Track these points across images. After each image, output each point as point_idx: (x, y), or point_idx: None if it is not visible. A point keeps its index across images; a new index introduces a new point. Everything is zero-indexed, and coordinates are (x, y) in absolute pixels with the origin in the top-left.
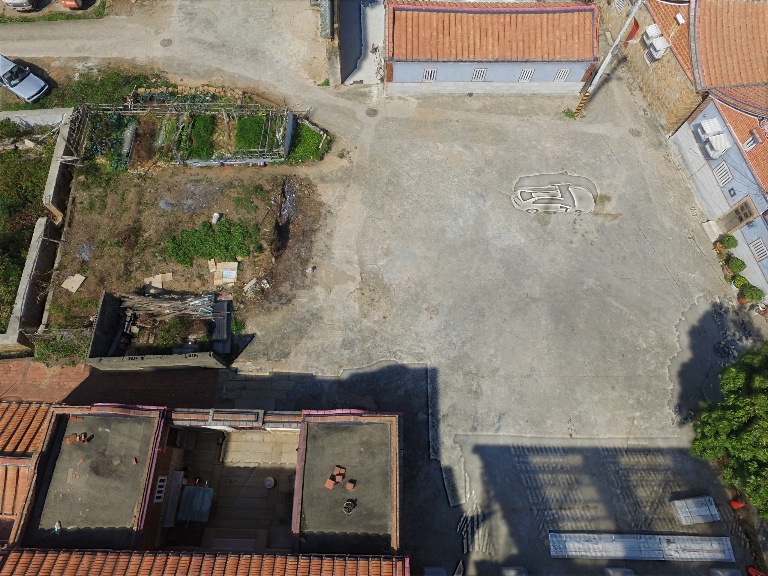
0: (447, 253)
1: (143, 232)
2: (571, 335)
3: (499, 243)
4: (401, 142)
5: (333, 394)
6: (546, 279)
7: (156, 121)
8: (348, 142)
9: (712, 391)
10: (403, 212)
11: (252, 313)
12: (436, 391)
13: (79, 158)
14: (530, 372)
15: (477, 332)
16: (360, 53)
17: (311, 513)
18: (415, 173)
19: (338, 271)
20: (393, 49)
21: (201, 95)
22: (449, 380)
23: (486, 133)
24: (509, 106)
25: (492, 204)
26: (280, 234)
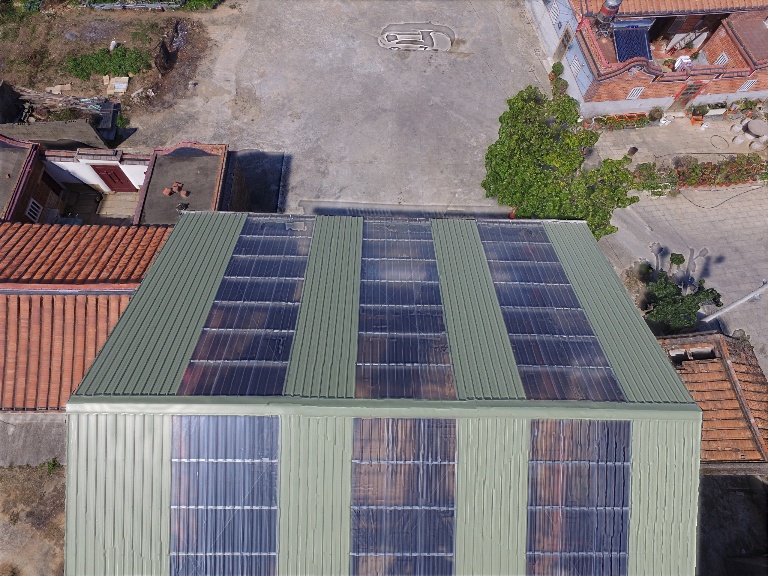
0: (315, 77)
1: (48, 55)
2: (412, 135)
3: (361, 70)
4: None
5: None
6: (398, 96)
7: None
8: None
9: None
10: (281, 47)
11: (137, 113)
12: (289, 171)
13: None
14: (372, 160)
15: (331, 131)
16: None
17: (150, 212)
18: (296, 20)
19: (217, 87)
20: None
21: None
22: (301, 164)
23: None
24: None
25: (360, 43)
26: (169, 58)
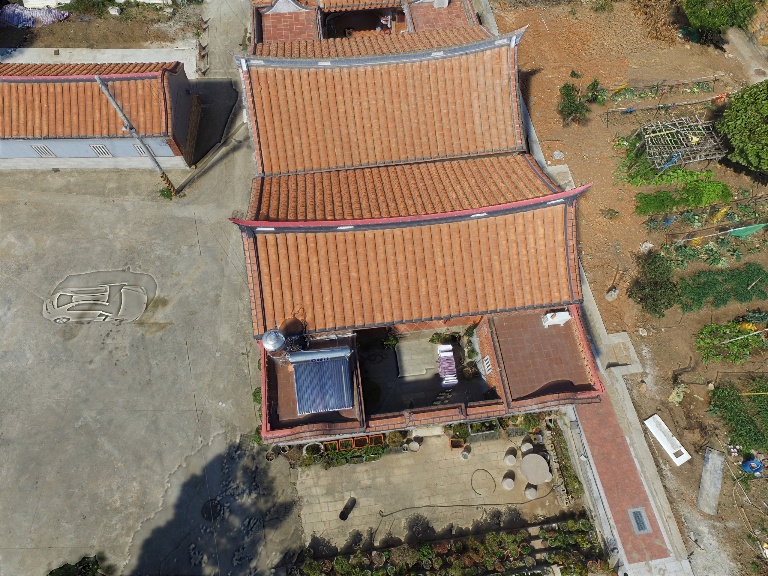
0: None
1: None
2: (31, 490)
3: None
4: None
5: None
6: (35, 413)
7: None
8: None
9: (171, 568)
10: None
11: None
12: None
13: None
14: None
15: None
16: None
17: None
18: None
19: None
20: None
21: None
22: None
23: (53, 219)
24: (97, 184)
25: (16, 312)
26: None
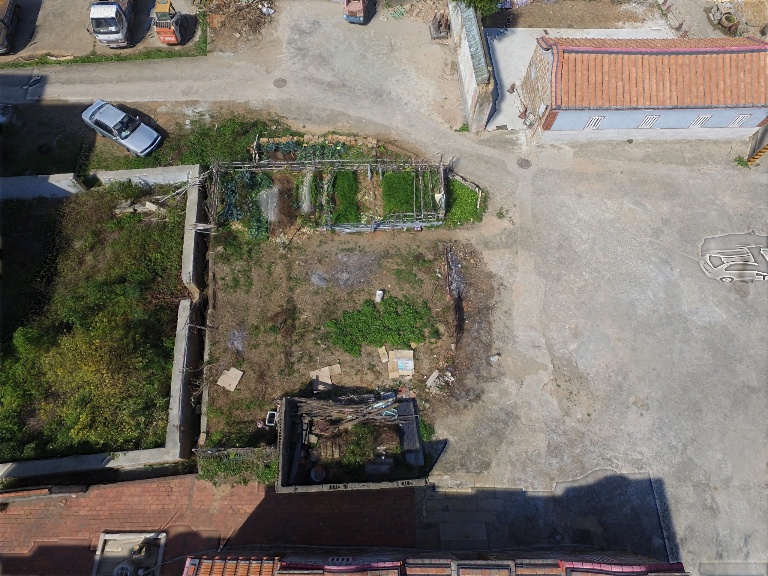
0: (643, 333)
1: (299, 314)
2: None
3: (699, 320)
4: (564, 199)
5: (550, 514)
6: (760, 363)
7: (291, 178)
8: (505, 199)
9: None
10: (584, 283)
11: (440, 413)
12: (666, 508)
13: (216, 226)
14: (767, 481)
15: (697, 431)
16: (497, 93)
17: None
18: (587, 236)
19: (526, 358)
20: (561, 96)
21: (330, 145)
22: (678, 493)
23: (656, 187)
24: (675, 154)
25: (681, 272)
26: None
